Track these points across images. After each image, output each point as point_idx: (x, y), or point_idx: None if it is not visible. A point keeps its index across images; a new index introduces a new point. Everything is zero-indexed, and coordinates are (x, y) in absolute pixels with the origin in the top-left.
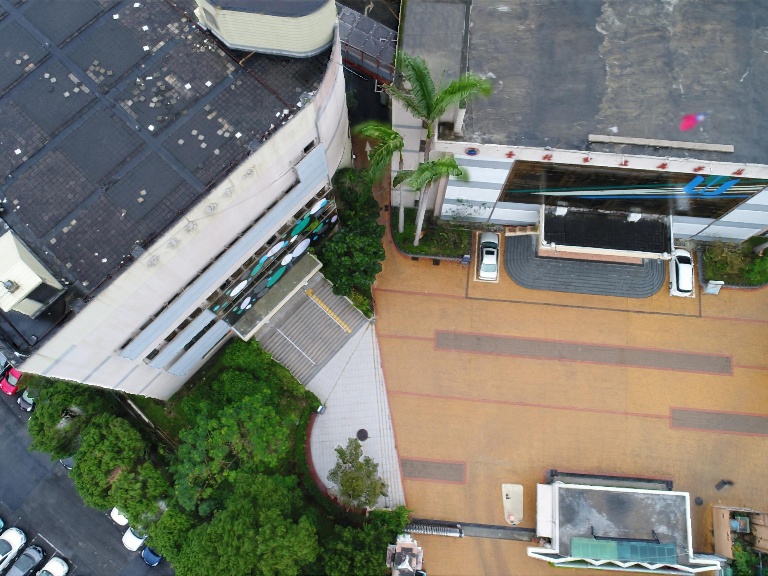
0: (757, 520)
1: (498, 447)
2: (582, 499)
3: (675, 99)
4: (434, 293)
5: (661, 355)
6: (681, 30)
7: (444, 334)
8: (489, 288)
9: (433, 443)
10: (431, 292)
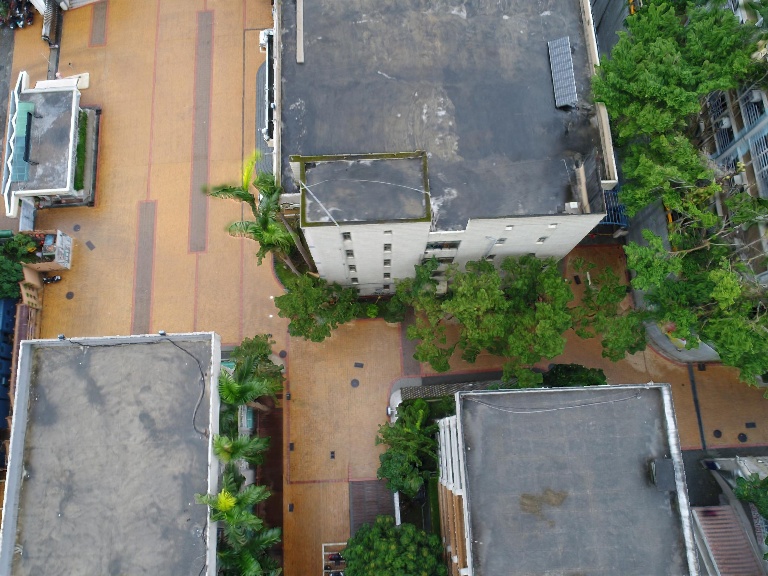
0: (56, 266)
1: (118, 67)
2: (64, 109)
3: (350, 16)
4: (246, 5)
5: (204, 190)
6: (430, 20)
7: (211, 17)
8: (255, 46)
9: (120, 20)
10: (247, 3)
